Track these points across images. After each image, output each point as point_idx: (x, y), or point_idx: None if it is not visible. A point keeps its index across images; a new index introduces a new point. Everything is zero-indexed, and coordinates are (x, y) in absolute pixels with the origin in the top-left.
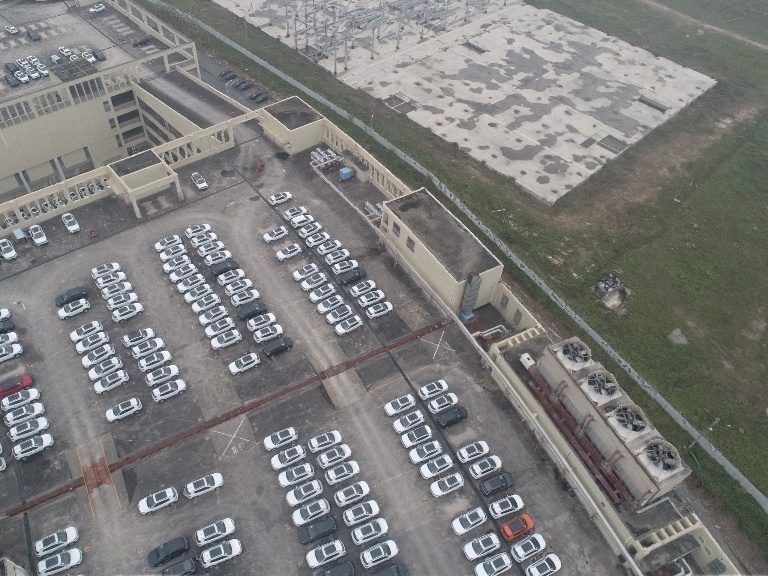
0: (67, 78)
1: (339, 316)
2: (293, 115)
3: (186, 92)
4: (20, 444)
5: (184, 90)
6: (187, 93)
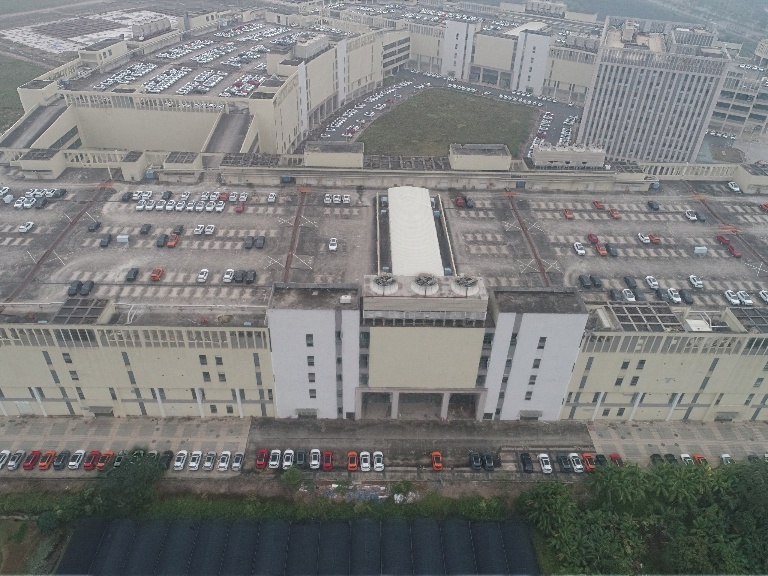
0: (53, 152)
1: (151, 66)
2: (38, 85)
3: (13, 145)
4: (249, 75)
5: (10, 146)
6: (14, 144)
